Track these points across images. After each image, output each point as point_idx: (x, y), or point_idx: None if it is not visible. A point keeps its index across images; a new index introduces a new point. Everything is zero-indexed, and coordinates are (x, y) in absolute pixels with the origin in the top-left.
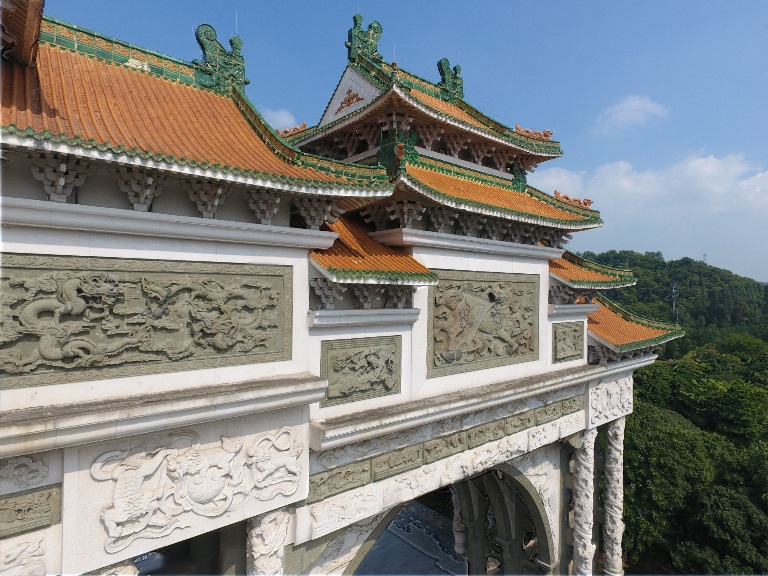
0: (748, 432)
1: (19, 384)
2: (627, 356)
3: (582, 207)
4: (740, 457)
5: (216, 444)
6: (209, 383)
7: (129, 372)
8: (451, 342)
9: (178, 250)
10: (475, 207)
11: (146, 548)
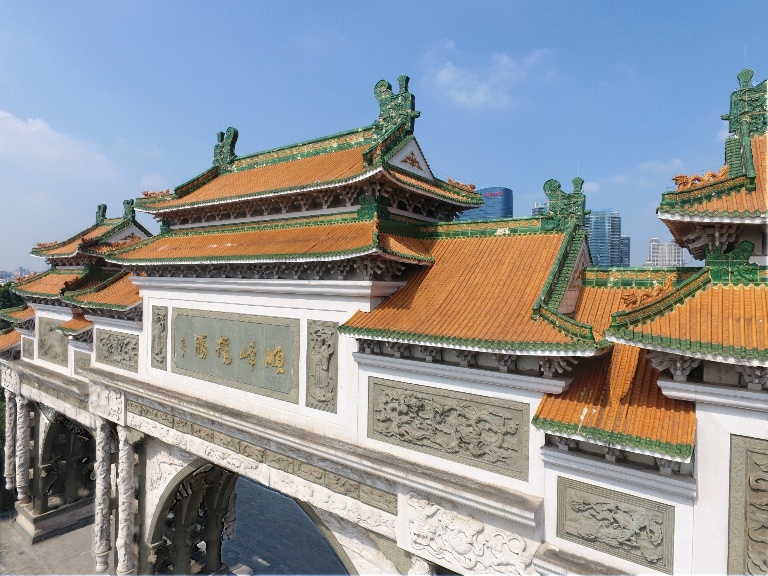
0: None
1: (387, 441)
2: None
3: None
4: None
5: (467, 518)
6: (466, 475)
7: (426, 451)
8: None
9: (450, 383)
10: None
11: (429, 558)
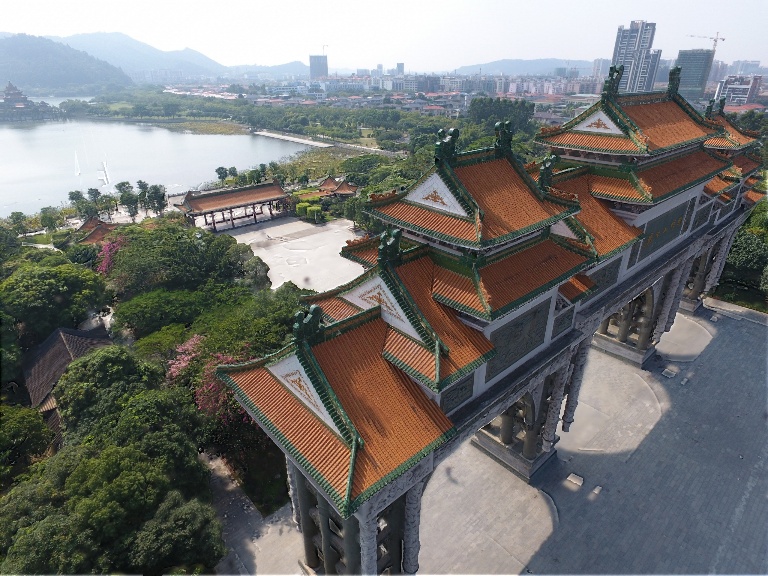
0: None
1: None
2: None
3: (352, 244)
4: (80, 557)
5: None
6: None
7: None
8: None
9: None
10: None
11: None
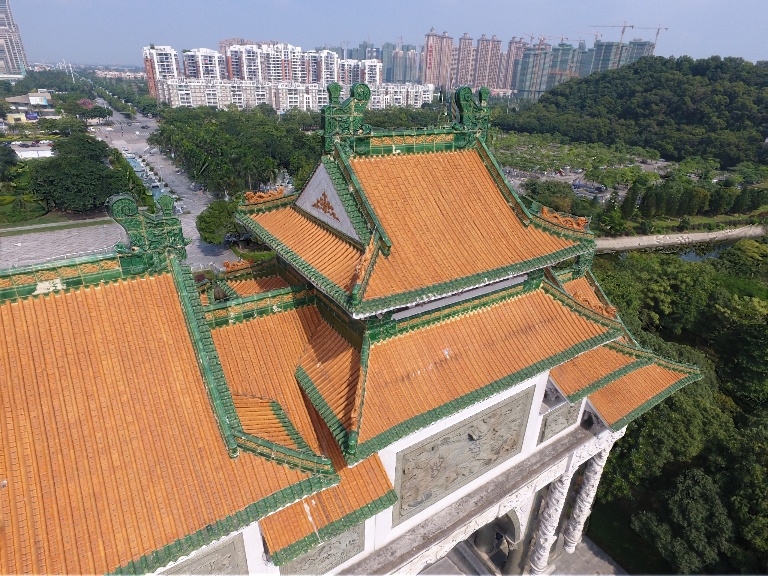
0: (766, 372)
1: None
2: None
3: (603, 315)
4: (731, 444)
5: None
6: None
7: None
8: (420, 493)
9: None
10: None
11: None
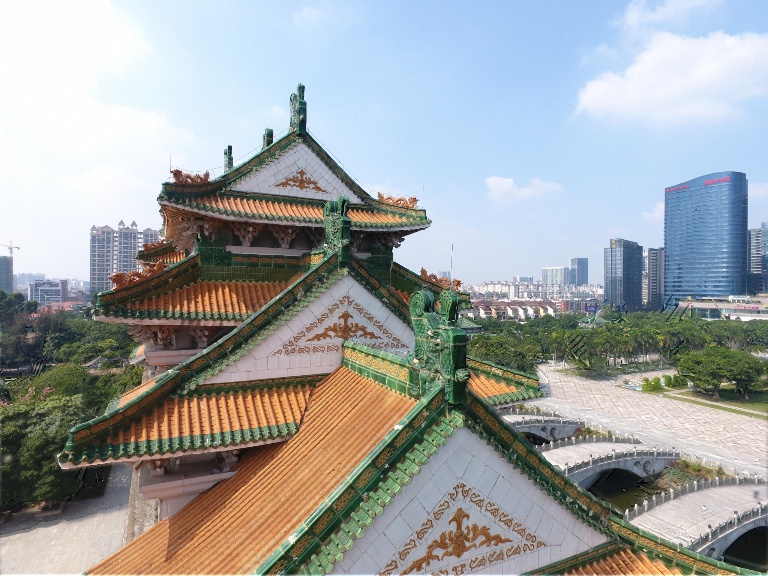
0: None
1: None
2: None
3: (124, 286)
4: None
5: None
6: None
7: None
8: None
9: None
10: None
11: None
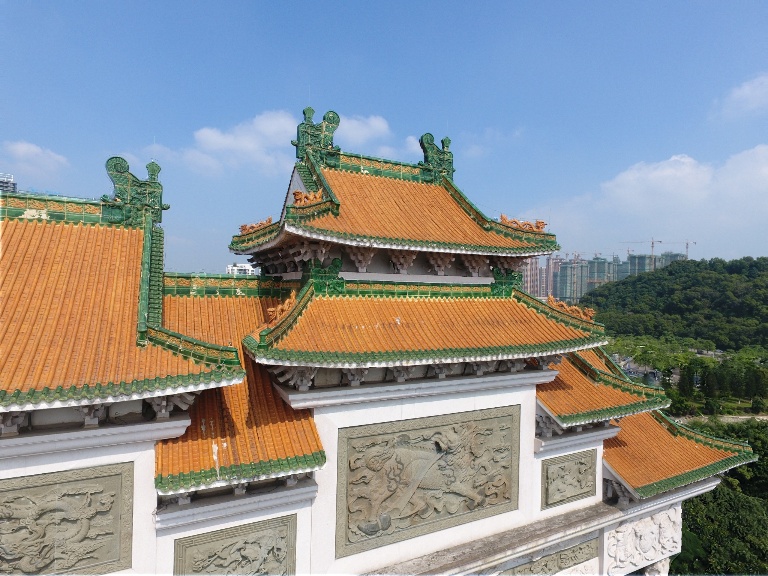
0: None
1: None
2: (661, 493)
3: (581, 319)
4: None
5: None
6: None
7: None
8: (373, 511)
9: None
10: (390, 361)
11: None
